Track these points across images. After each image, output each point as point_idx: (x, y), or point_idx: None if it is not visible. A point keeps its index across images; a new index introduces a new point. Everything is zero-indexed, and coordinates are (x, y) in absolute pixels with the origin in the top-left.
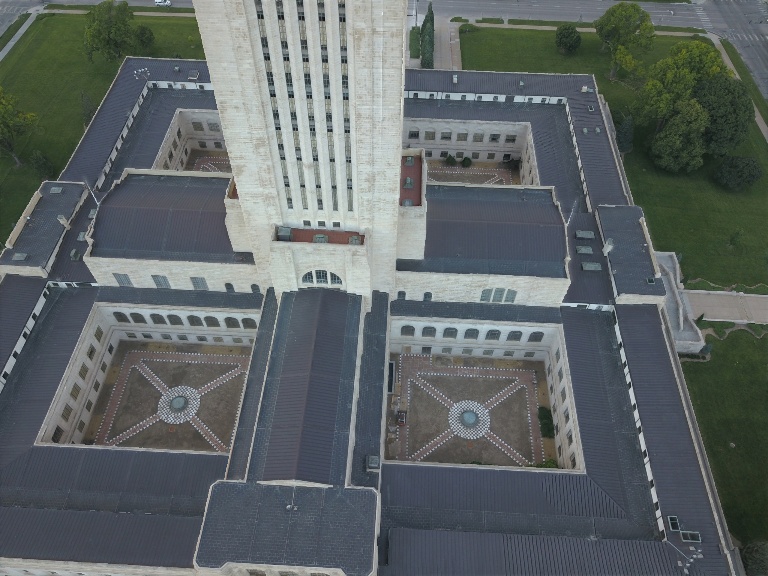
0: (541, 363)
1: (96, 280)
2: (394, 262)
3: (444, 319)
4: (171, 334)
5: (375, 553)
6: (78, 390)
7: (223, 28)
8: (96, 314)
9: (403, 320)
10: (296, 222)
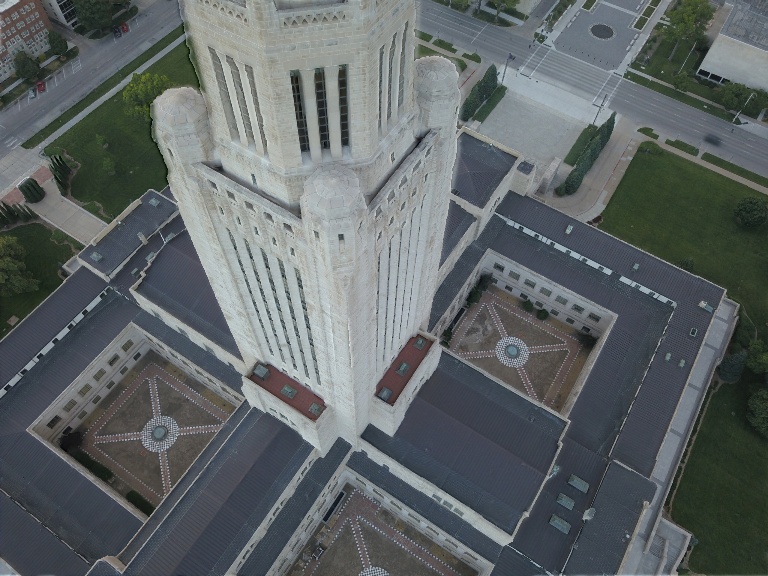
0: (475, 573)
1: (139, 304)
2: (355, 434)
3: (389, 496)
4: (184, 368)
5: None
6: (89, 388)
7: (206, 242)
8: (129, 332)
9: (355, 475)
10: (276, 366)
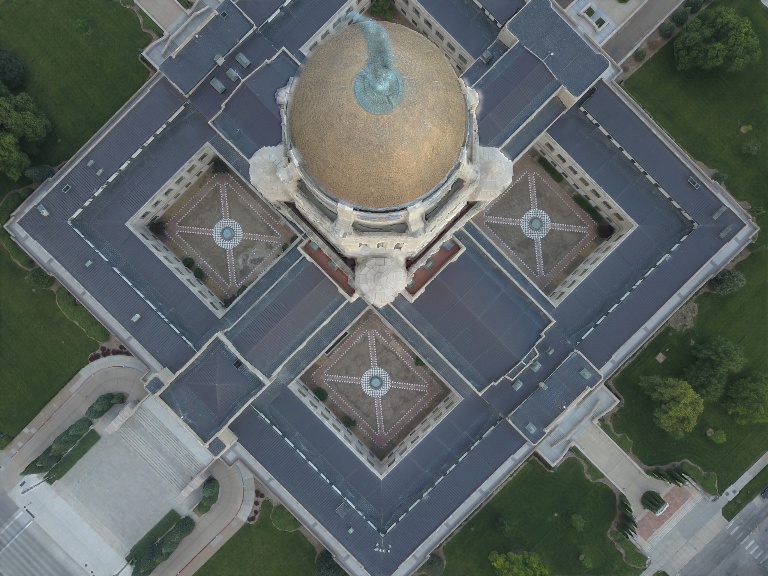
0: None
1: None
2: None
3: None
4: None
5: (531, 0)
6: None
7: None
8: None
9: None
10: None
